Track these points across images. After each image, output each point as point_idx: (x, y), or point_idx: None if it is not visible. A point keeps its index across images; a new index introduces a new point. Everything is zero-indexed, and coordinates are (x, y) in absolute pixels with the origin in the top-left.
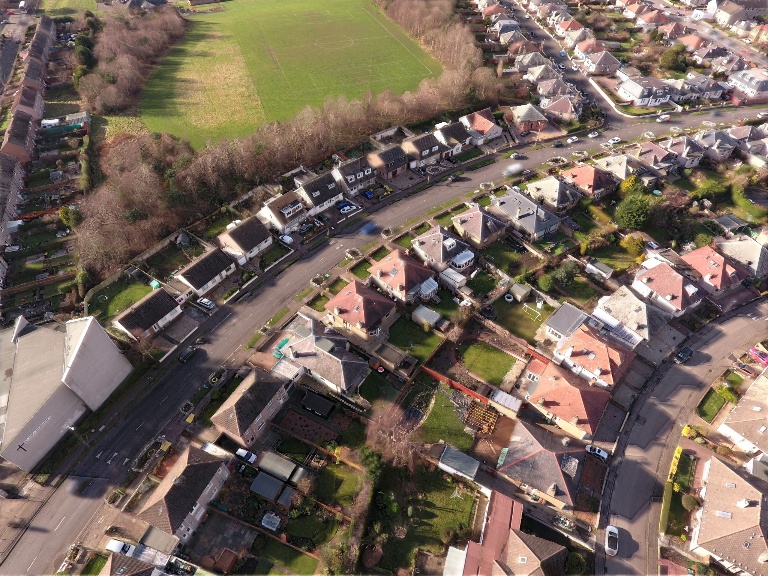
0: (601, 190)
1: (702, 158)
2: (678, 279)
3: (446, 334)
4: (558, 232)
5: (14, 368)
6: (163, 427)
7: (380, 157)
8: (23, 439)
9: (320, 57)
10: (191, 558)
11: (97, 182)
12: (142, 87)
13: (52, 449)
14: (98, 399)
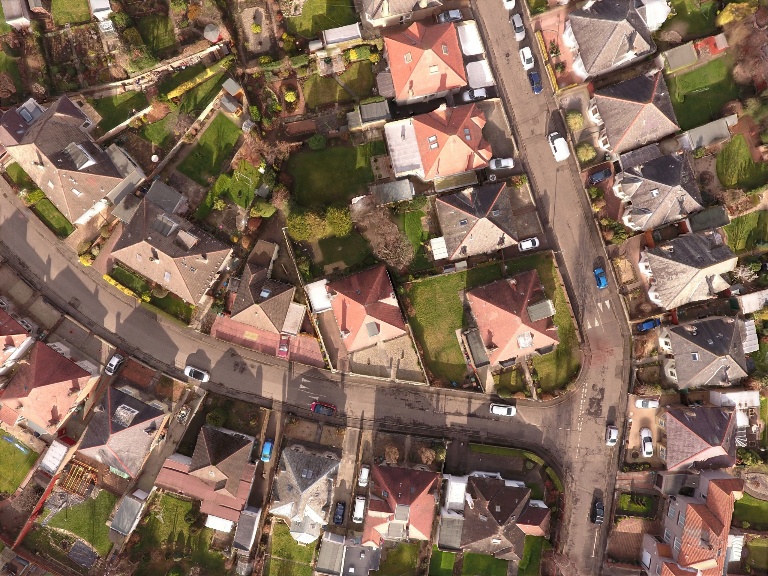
0: None
1: None
2: None
3: None
4: None
5: None
6: None
7: None
8: None
9: None
10: None
11: None
12: None
13: None
14: None
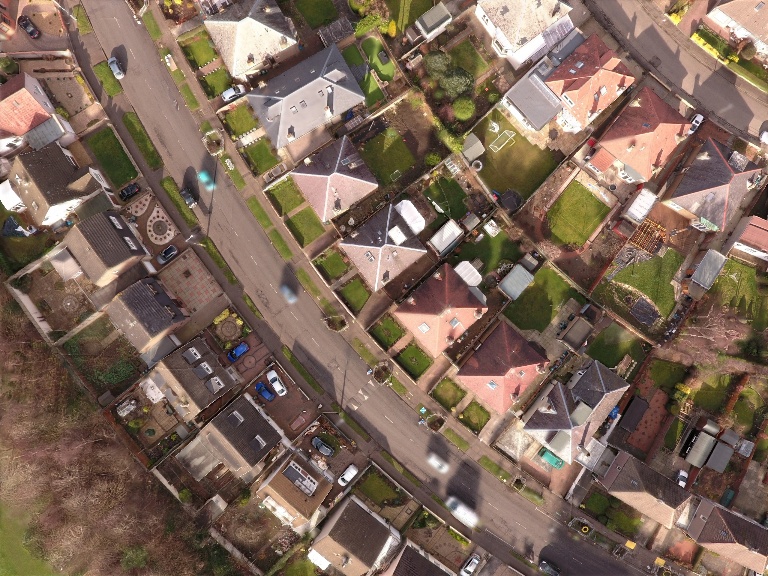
0: None
1: None
2: None
3: (541, 260)
4: None
5: None
6: (638, 570)
7: (158, 332)
8: None
9: None
10: (765, 513)
11: None
12: None
13: None
14: None
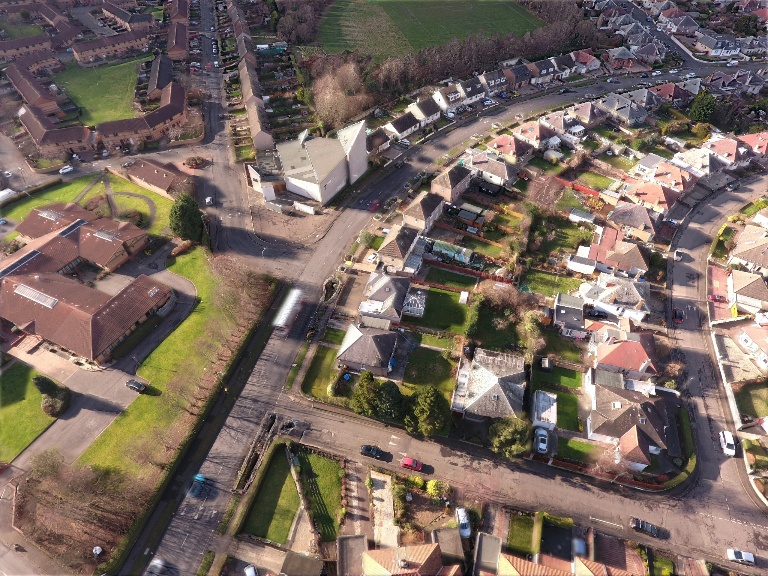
0: (679, 99)
1: (762, 88)
2: (734, 143)
3: None
4: (645, 123)
5: (309, 154)
6: (395, 194)
7: (512, 71)
8: (327, 182)
9: (448, 15)
10: None
11: (307, 82)
12: (317, 29)
13: (332, 198)
14: (354, 178)
